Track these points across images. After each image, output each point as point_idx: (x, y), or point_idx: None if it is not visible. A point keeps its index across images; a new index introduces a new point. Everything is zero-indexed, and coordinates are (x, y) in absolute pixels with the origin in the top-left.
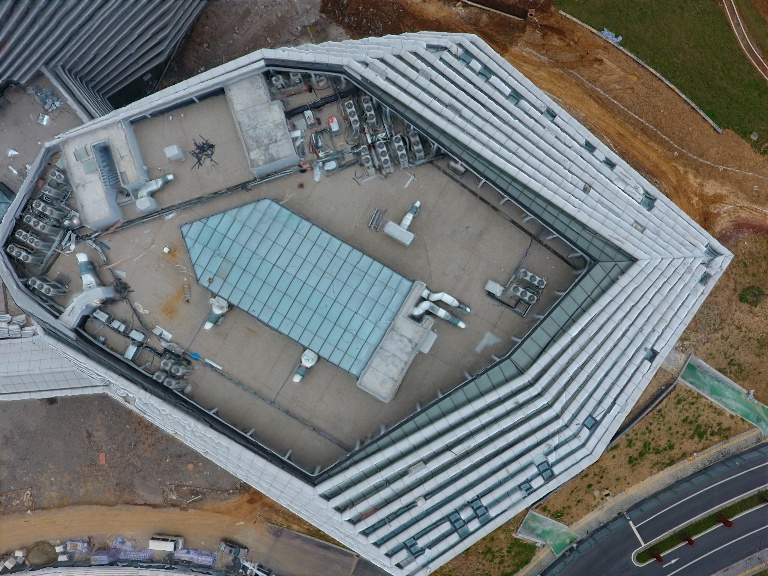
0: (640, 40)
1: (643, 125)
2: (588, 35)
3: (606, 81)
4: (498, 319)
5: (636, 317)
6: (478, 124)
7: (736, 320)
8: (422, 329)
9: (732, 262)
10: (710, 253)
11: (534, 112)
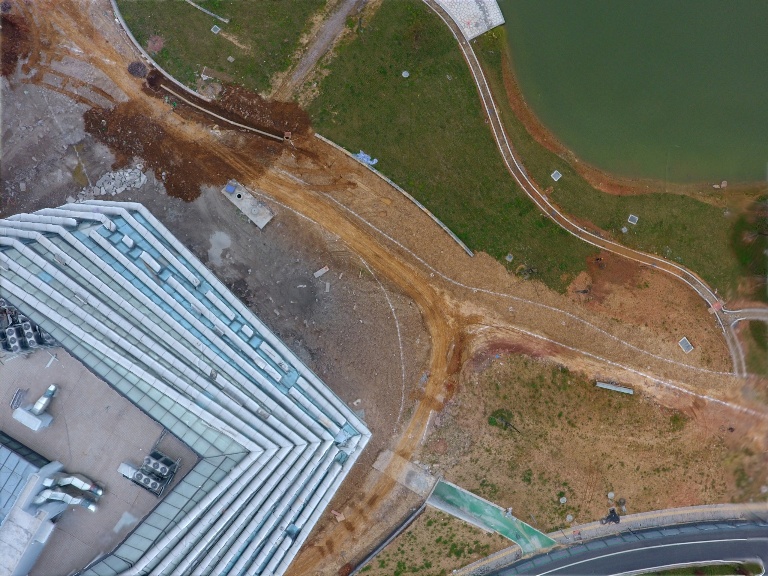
0: (396, 162)
1: (398, 247)
2: (342, 159)
3: (359, 205)
4: (135, 499)
5: (265, 500)
6: (104, 312)
7: (485, 443)
8: (37, 520)
9: (484, 384)
10: (350, 431)
11: (181, 289)
